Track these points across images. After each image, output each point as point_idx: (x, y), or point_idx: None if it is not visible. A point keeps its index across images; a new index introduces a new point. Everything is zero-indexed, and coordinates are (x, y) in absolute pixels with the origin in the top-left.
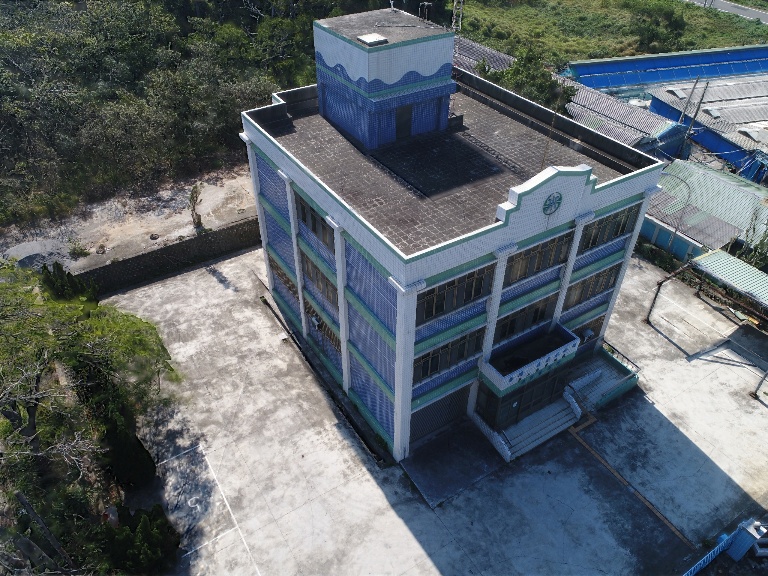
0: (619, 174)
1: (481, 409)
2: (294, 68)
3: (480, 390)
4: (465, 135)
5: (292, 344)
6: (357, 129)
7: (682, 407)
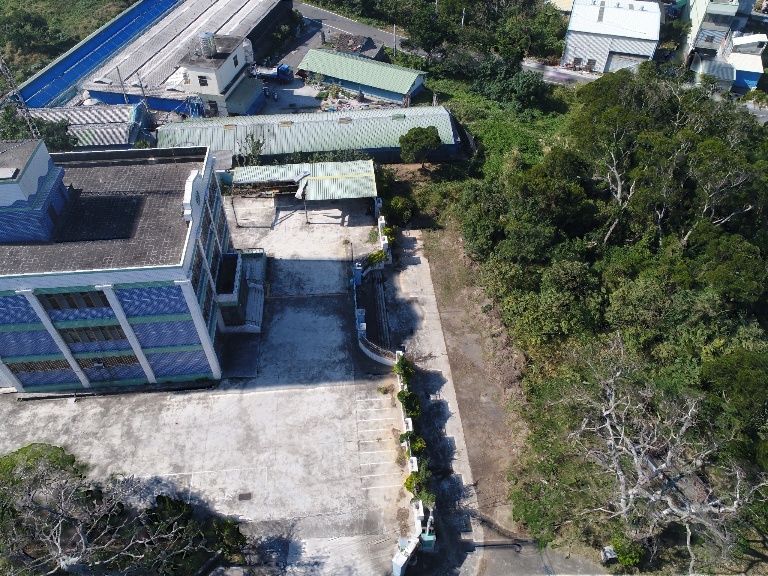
0: (191, 163)
1: (229, 322)
2: None
3: (223, 312)
4: (87, 194)
5: (84, 398)
6: (25, 234)
7: (291, 250)
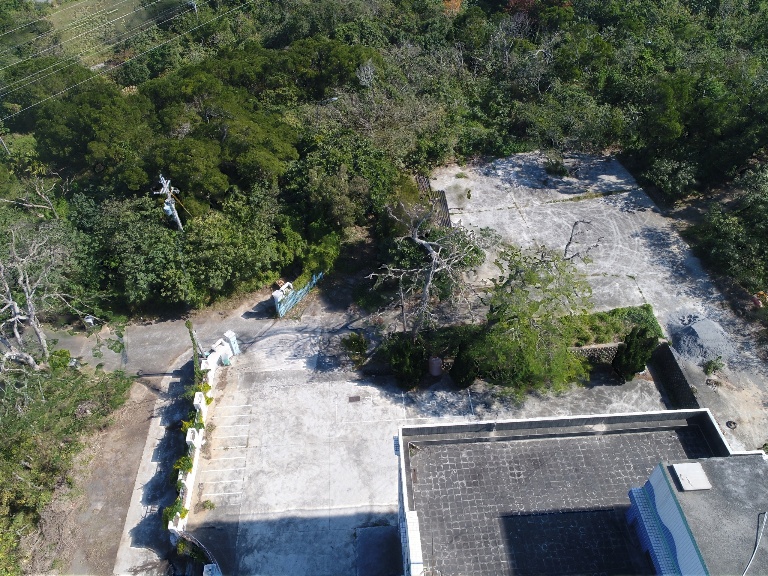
0: None
1: None
2: None
3: None
4: None
5: None
6: None
7: None
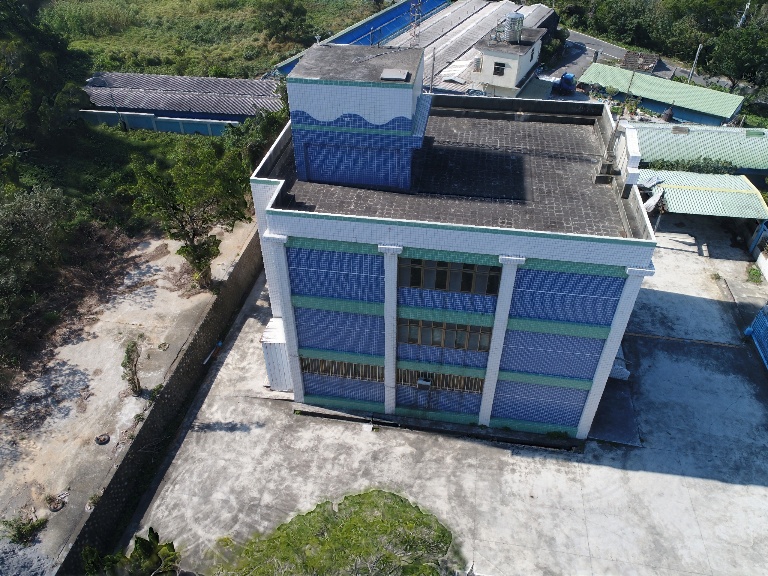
0: (574, 125)
1: None
2: (18, 166)
3: None
4: (443, 143)
5: (385, 427)
6: (380, 175)
7: None
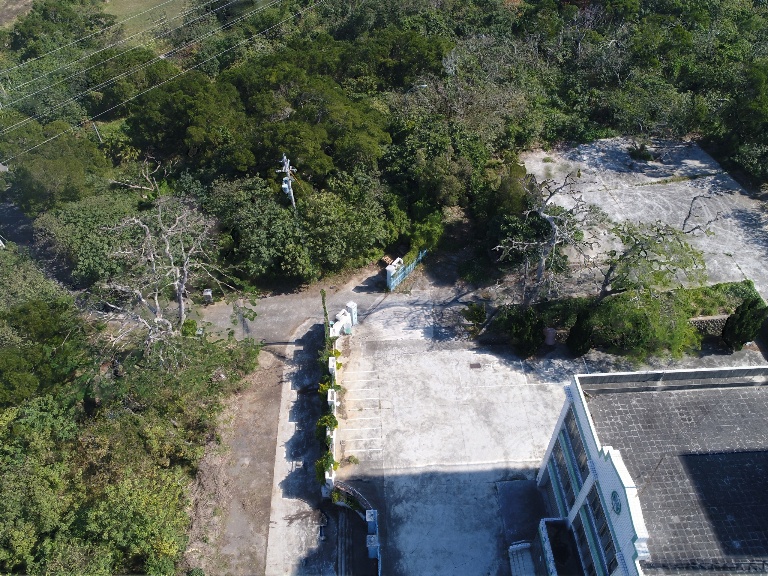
0: None
1: None
2: None
3: None
4: None
5: None
6: None
7: None
